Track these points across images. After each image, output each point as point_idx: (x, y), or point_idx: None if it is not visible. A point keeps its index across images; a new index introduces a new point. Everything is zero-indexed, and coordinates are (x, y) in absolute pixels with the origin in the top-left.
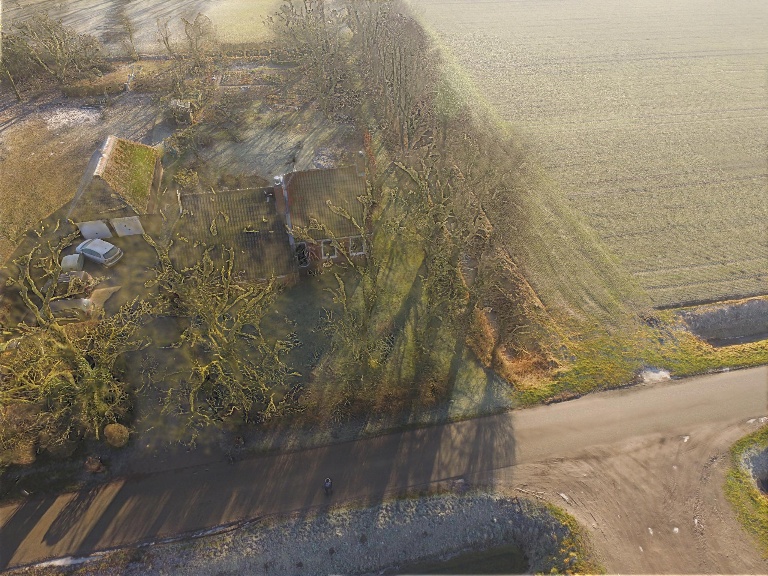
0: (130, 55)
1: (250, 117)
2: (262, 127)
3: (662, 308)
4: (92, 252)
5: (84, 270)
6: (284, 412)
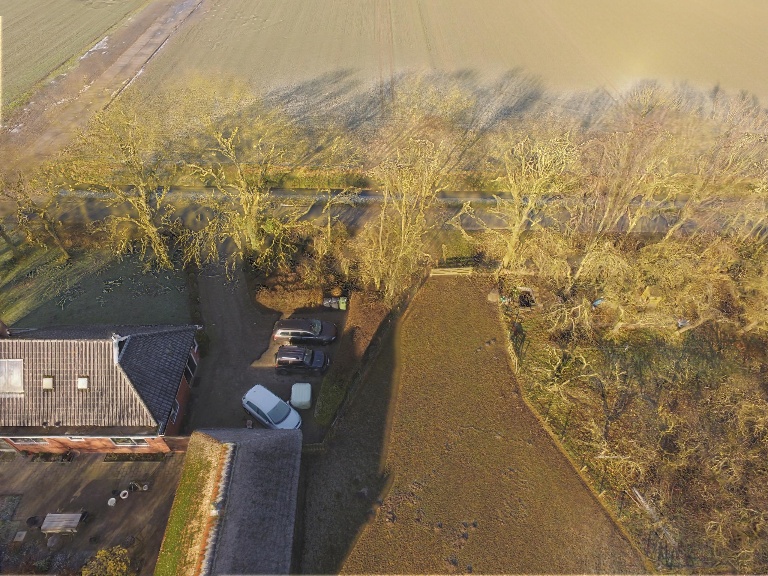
0: None
1: None
2: None
3: None
4: None
5: None
6: None
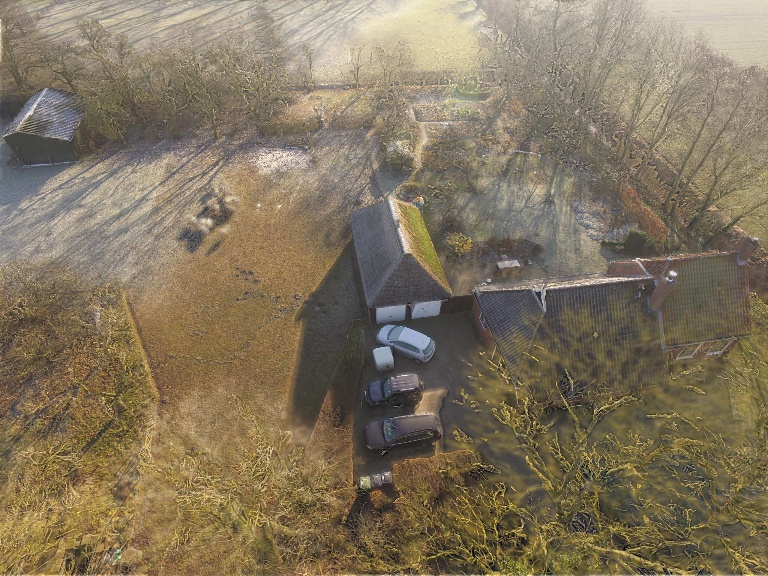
0: (306, 84)
1: (473, 161)
2: (493, 174)
3: None
4: (407, 346)
5: (394, 366)
6: None
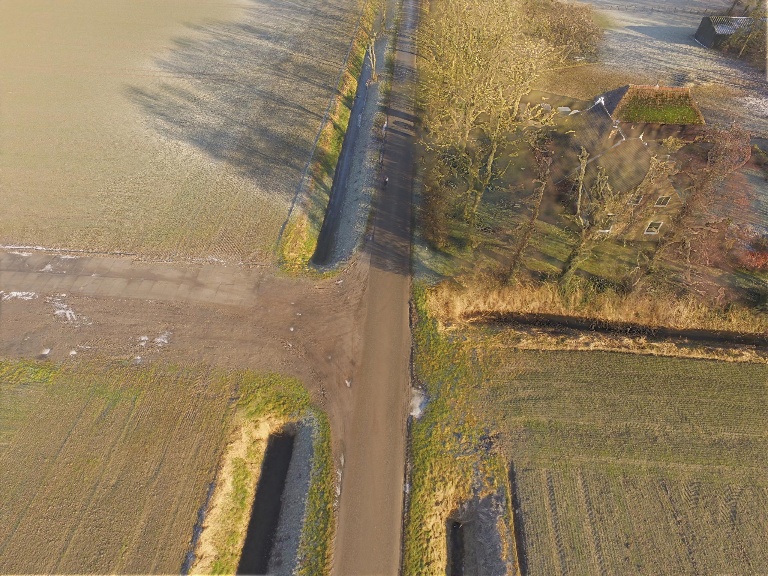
0: None
1: None
2: None
3: (513, 477)
4: None
5: None
6: (438, 179)
